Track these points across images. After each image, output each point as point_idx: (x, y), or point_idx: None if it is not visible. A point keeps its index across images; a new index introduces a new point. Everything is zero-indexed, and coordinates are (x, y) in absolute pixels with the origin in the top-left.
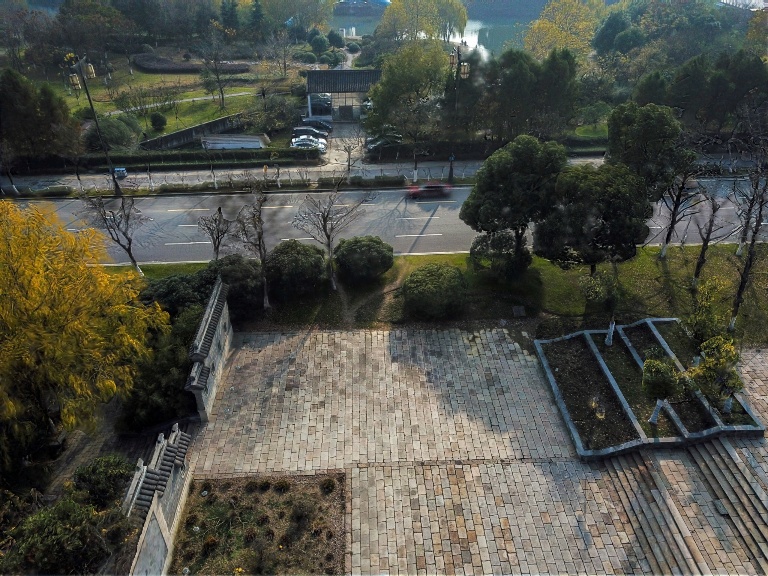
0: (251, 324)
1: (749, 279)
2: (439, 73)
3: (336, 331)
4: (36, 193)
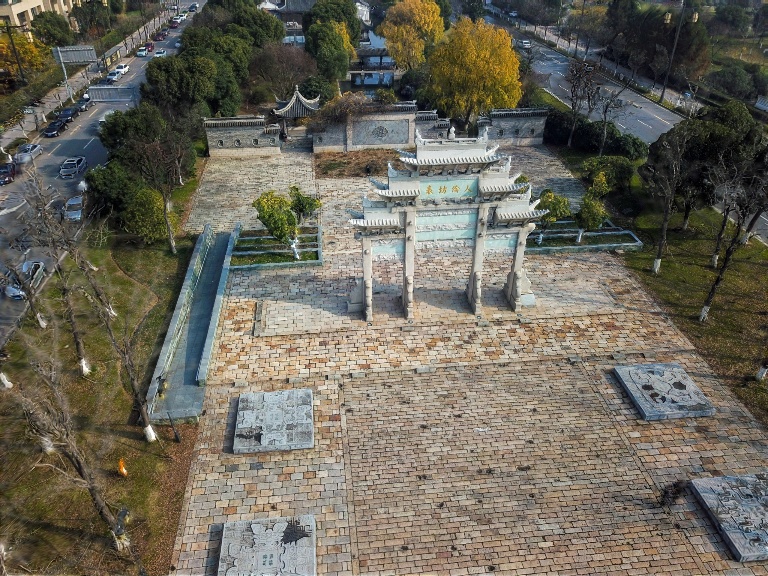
0: (554, 147)
1: (767, 301)
2: None
3: (563, 165)
4: (636, 87)
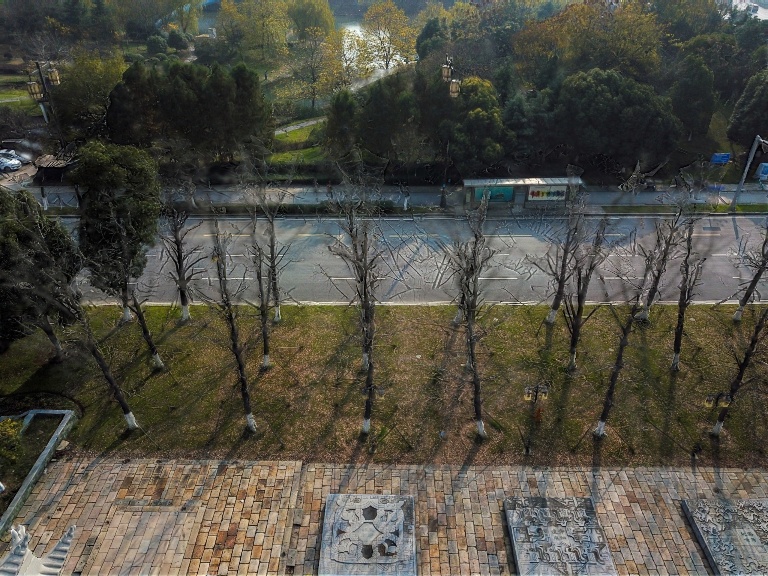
0: None
1: None
2: (107, 87)
3: None
4: None
